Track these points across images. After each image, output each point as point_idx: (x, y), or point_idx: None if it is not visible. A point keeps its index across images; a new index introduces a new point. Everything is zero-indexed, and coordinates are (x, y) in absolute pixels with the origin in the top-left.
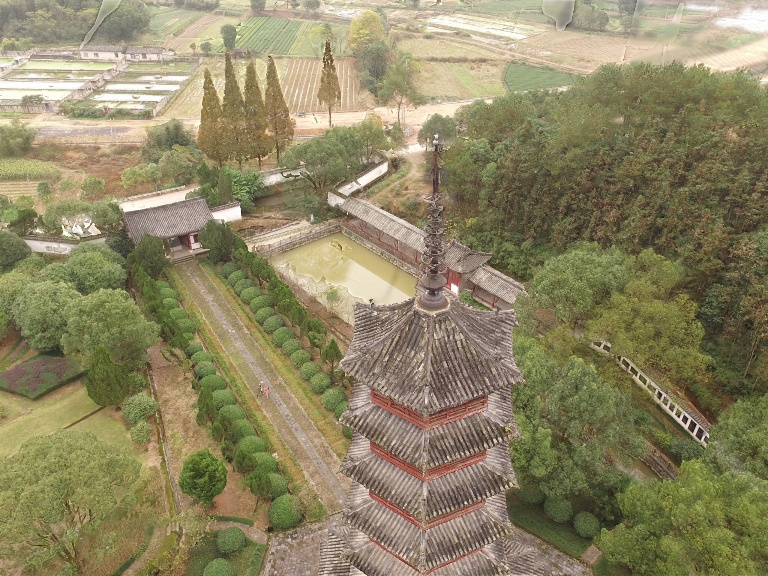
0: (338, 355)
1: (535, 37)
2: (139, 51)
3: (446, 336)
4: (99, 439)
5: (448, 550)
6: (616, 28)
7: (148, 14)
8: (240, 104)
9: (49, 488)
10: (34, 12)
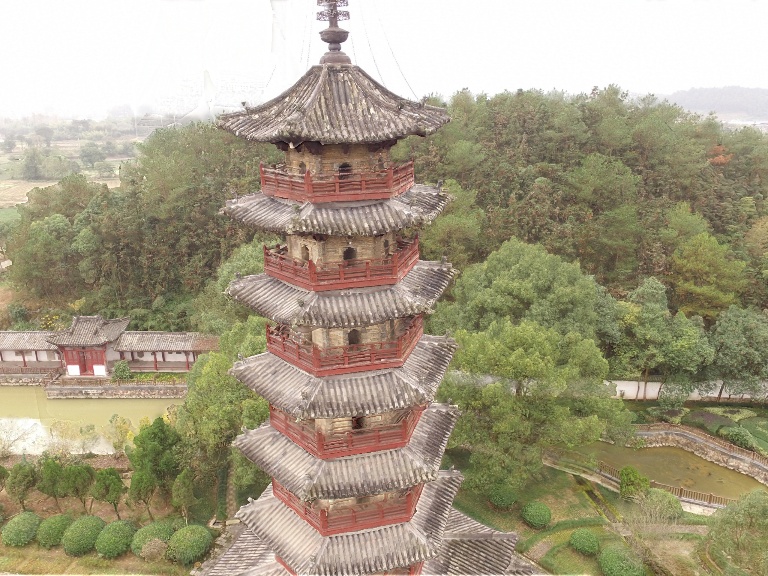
0: (1, 471)
1: (6, 190)
2: None
3: None
4: None
5: (430, 379)
6: (89, 175)
7: None
8: None
9: None
10: None
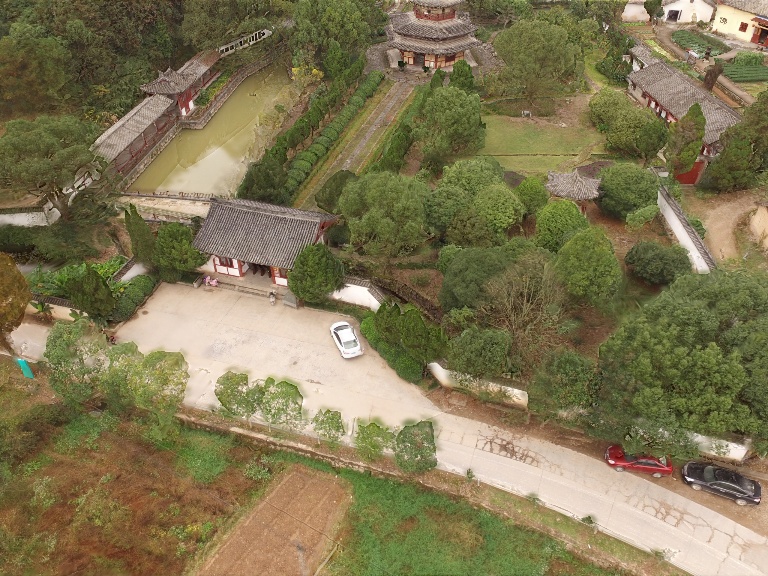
0: None
1: None
2: None
3: None
4: (490, 141)
5: None
6: None
7: None
8: None
9: None
10: None
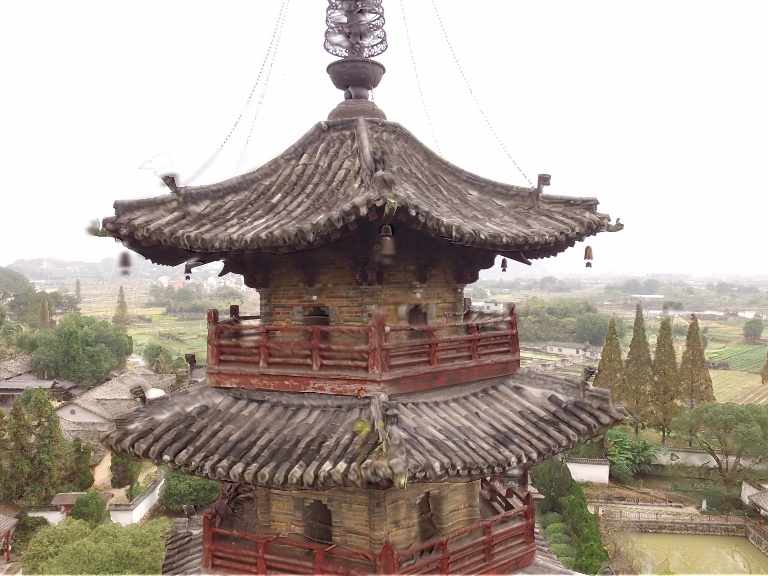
0: None
1: None
2: (599, 350)
3: (326, 163)
4: None
5: None
6: None
7: (625, 329)
8: (647, 362)
9: (112, 553)
10: (526, 317)
